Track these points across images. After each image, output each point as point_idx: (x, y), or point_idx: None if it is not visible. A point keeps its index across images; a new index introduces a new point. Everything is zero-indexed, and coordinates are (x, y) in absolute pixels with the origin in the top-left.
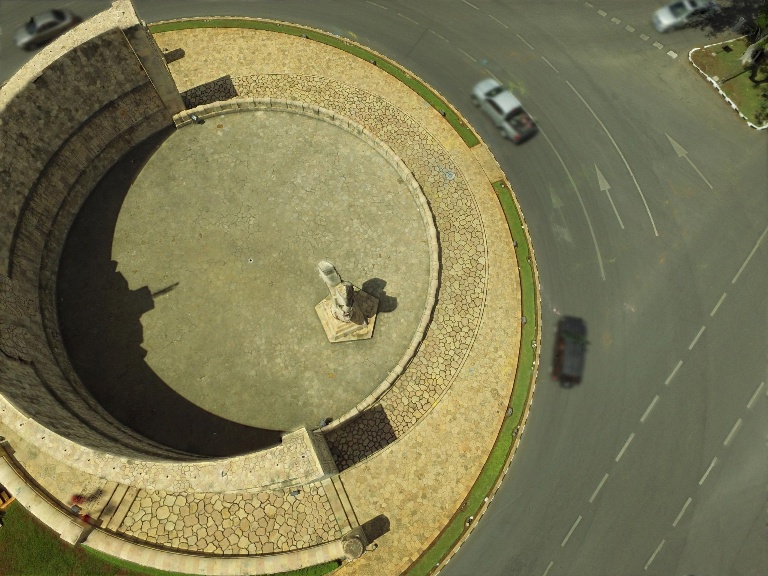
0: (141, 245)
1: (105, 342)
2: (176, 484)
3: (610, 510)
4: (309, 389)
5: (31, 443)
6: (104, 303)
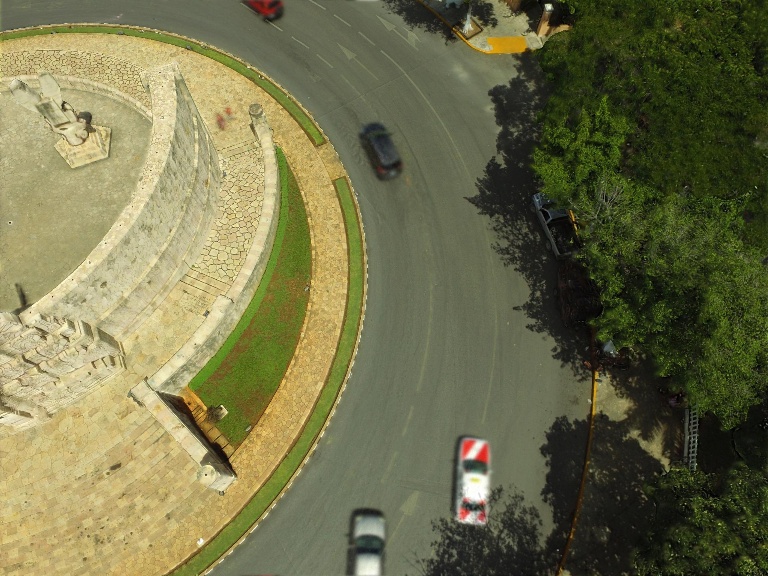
0: None
1: None
2: (164, 147)
3: (264, 5)
4: None
5: (108, 253)
6: None
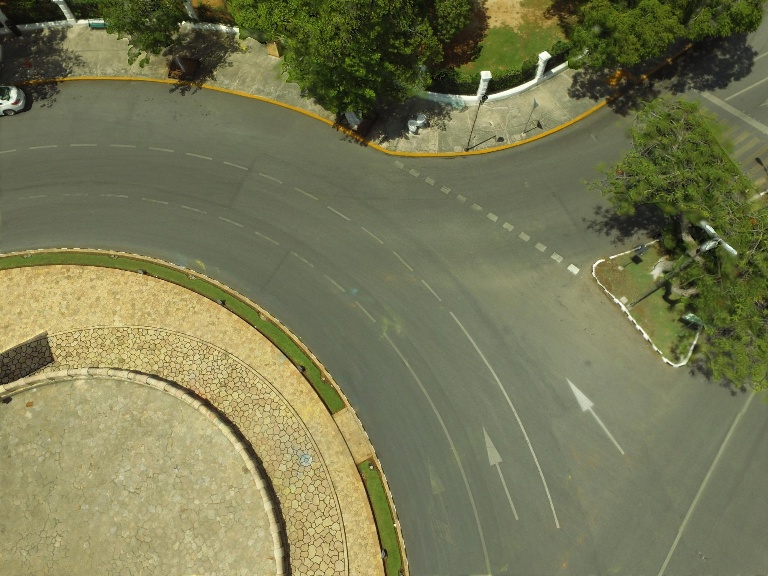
0: None
1: None
2: None
3: None
4: None
5: None
6: None
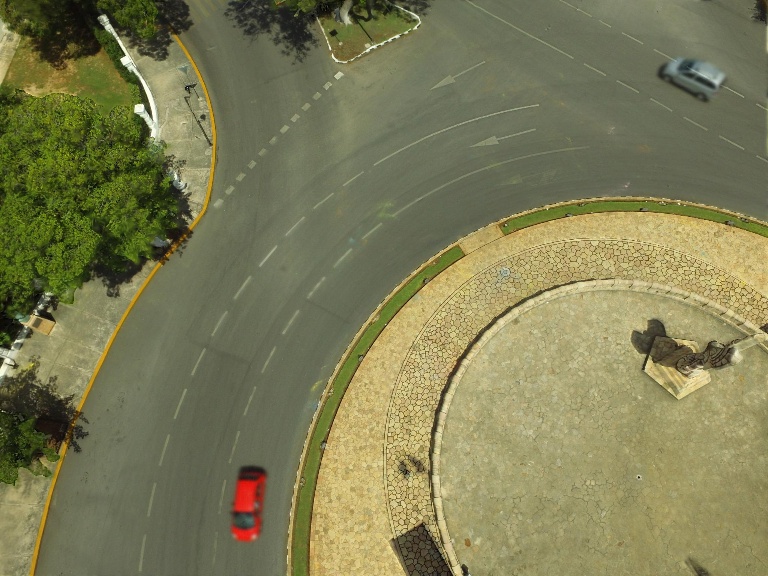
0: None
1: None
2: None
3: None
4: (762, 398)
5: None
6: None
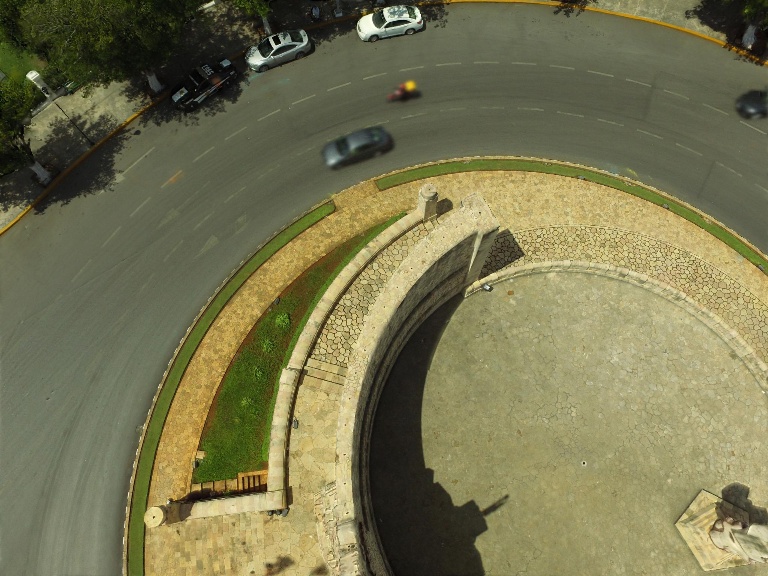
0: (455, 447)
1: (441, 575)
2: None
3: None
4: None
5: None
6: (429, 524)
